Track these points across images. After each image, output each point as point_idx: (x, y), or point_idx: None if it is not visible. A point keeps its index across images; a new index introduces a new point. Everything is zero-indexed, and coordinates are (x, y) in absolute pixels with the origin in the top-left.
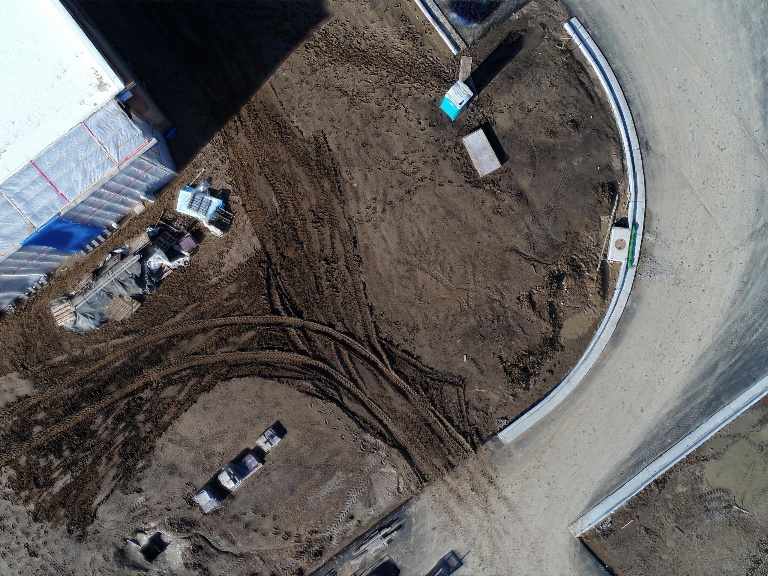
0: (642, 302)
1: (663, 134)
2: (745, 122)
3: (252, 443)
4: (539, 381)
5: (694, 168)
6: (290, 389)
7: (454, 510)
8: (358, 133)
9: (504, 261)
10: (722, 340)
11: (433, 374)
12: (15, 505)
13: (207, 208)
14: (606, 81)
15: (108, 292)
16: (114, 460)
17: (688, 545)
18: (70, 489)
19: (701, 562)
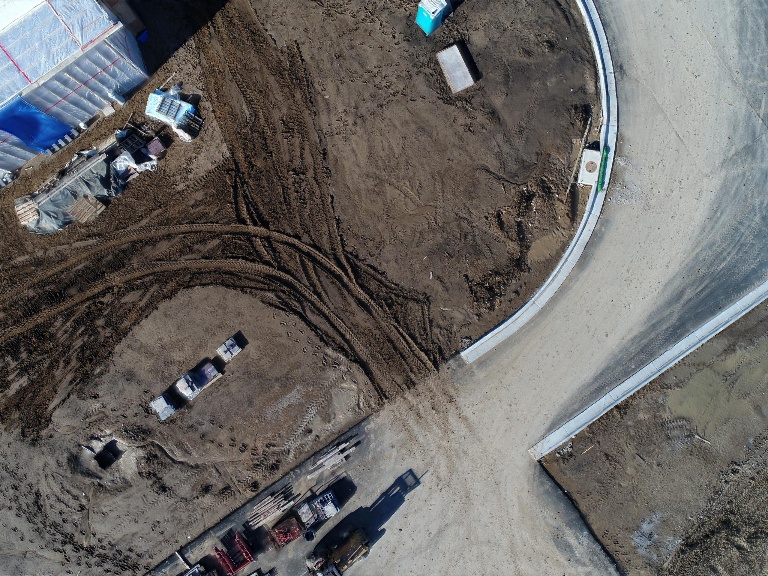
0: (611, 226)
1: (638, 59)
2: (720, 50)
3: (213, 353)
4: (504, 302)
5: (667, 94)
6: (253, 299)
7: (414, 428)
8: (332, 44)
9: (474, 179)
10: (689, 268)
11: (398, 290)
12: None
13: (176, 112)
14: (582, 3)
15: (72, 191)
16: (72, 364)
17: (648, 473)
18: (26, 392)
19: (661, 491)
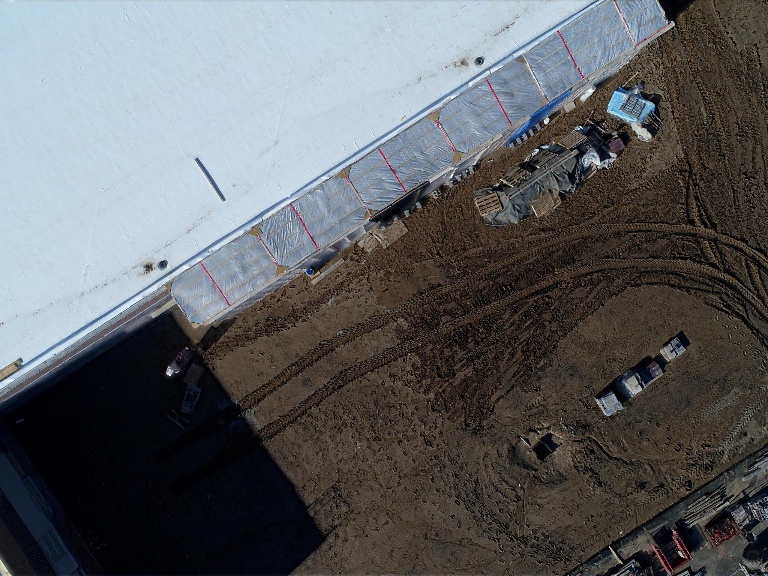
0: None
1: None
2: None
3: (654, 351)
4: None
5: None
6: (697, 301)
7: None
8: None
9: None
10: None
11: None
12: (416, 393)
13: (640, 111)
14: None
15: (541, 185)
16: (517, 356)
17: None
18: (471, 382)
19: None
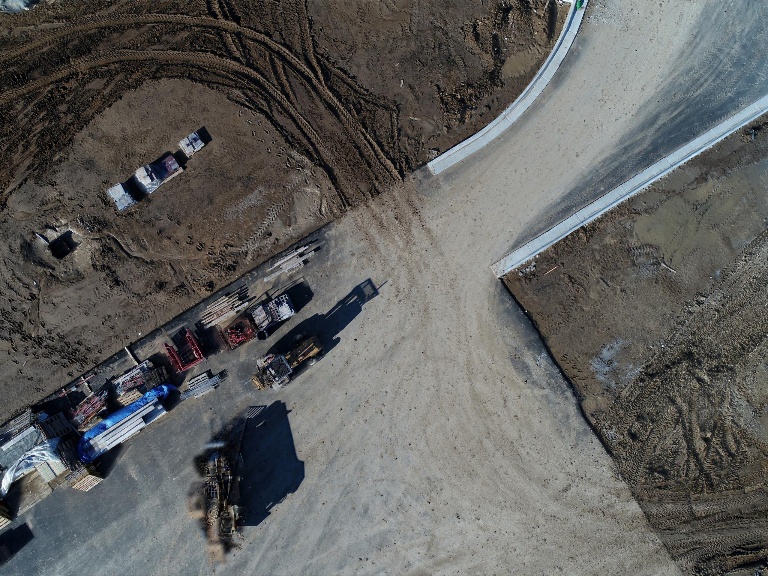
0: (588, 45)
1: None
2: None
3: (175, 147)
4: (475, 116)
5: None
6: (219, 96)
7: (375, 237)
8: None
9: None
10: (665, 92)
11: (367, 96)
12: None
13: None
14: None
15: None
16: (31, 149)
17: (611, 299)
18: None
19: (623, 317)
